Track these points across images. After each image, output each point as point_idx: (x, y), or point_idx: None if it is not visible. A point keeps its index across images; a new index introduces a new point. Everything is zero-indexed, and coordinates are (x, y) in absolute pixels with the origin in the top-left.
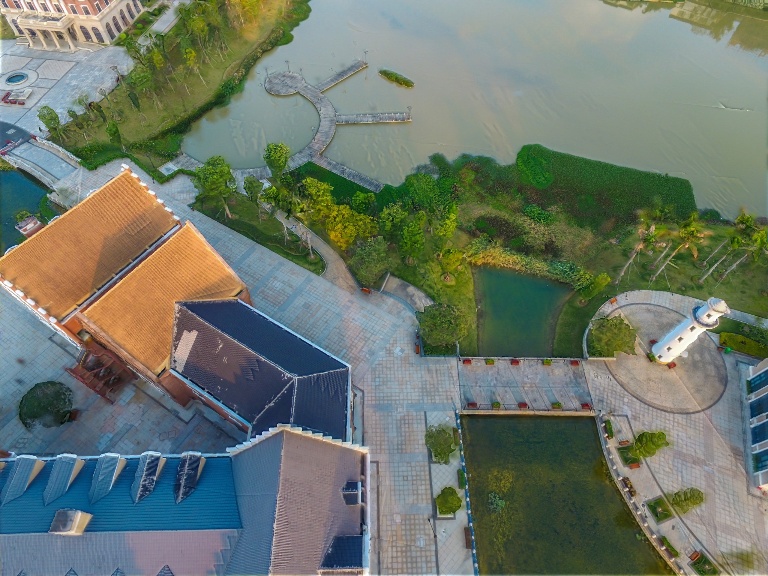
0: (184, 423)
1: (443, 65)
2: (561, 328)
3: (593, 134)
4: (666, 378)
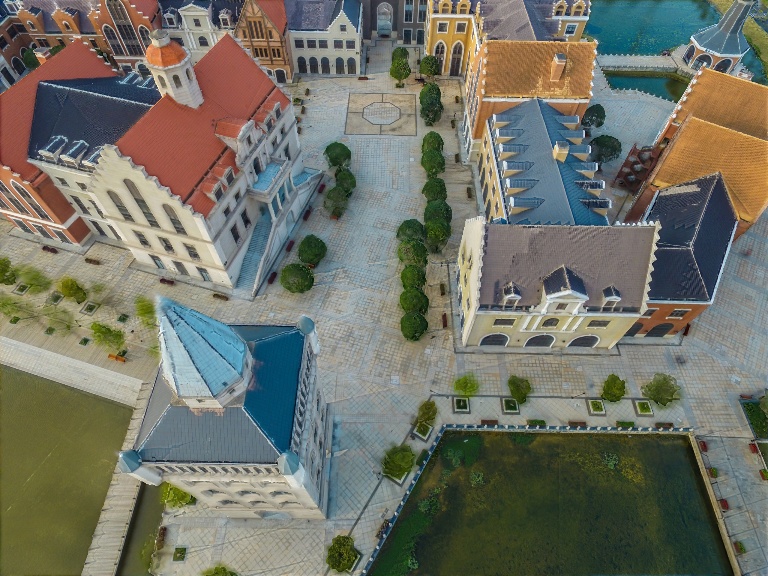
0: None
1: None
2: None
3: None
4: None
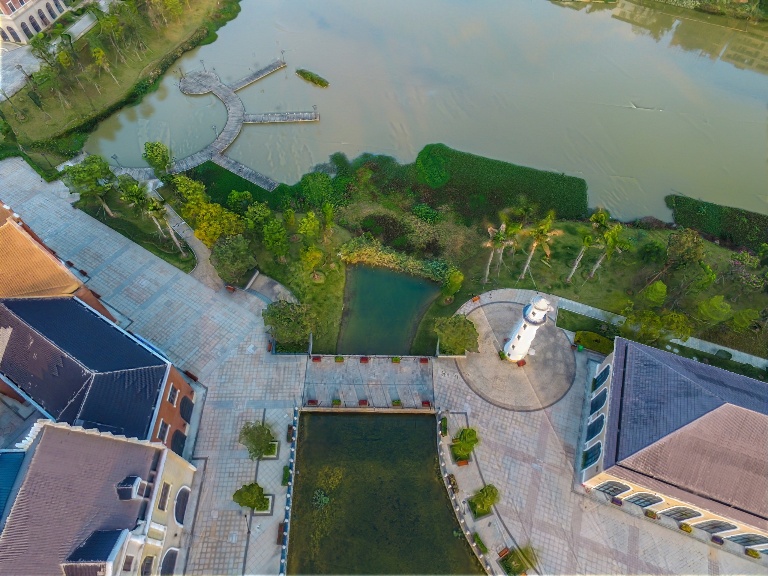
0: (22, 419)
1: (361, 65)
2: (423, 326)
3: (498, 133)
4: (513, 376)
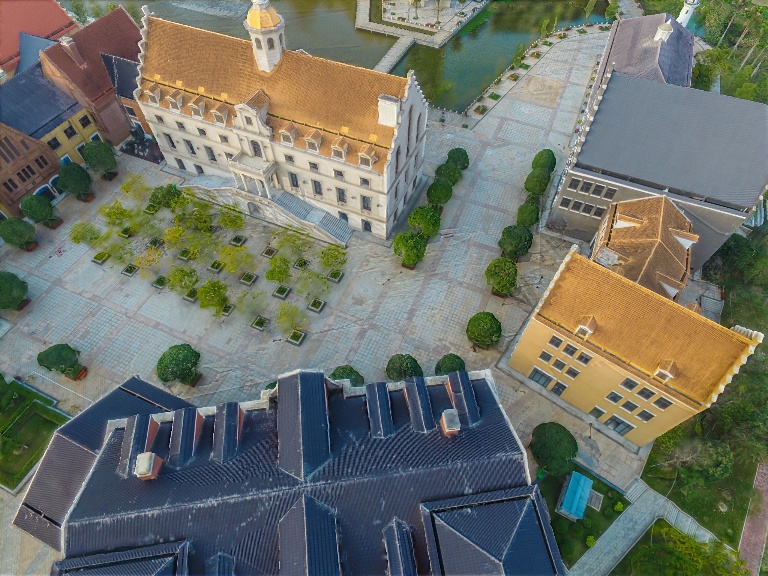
0: None
1: None
2: None
3: None
4: None
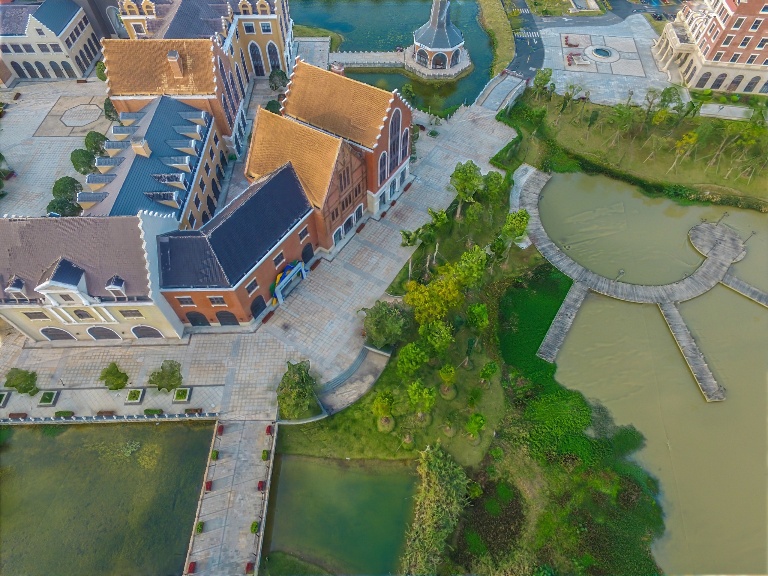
0: None
1: None
2: (313, 572)
3: None
4: None
